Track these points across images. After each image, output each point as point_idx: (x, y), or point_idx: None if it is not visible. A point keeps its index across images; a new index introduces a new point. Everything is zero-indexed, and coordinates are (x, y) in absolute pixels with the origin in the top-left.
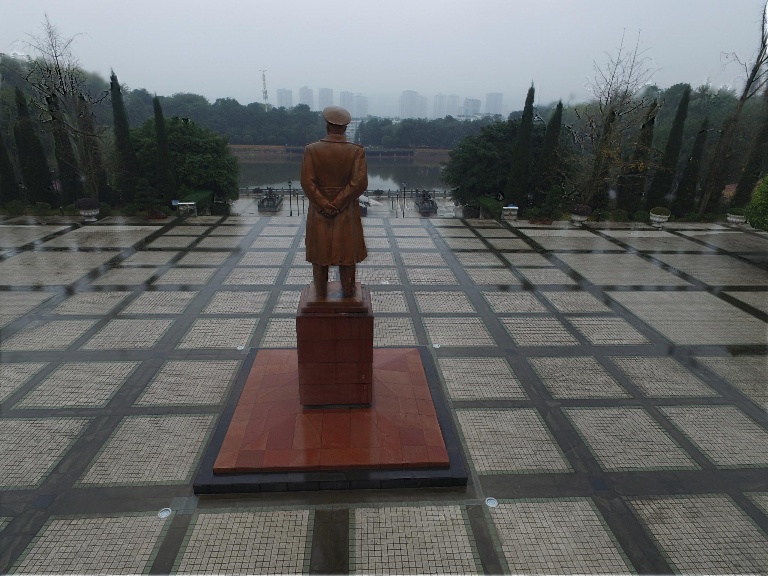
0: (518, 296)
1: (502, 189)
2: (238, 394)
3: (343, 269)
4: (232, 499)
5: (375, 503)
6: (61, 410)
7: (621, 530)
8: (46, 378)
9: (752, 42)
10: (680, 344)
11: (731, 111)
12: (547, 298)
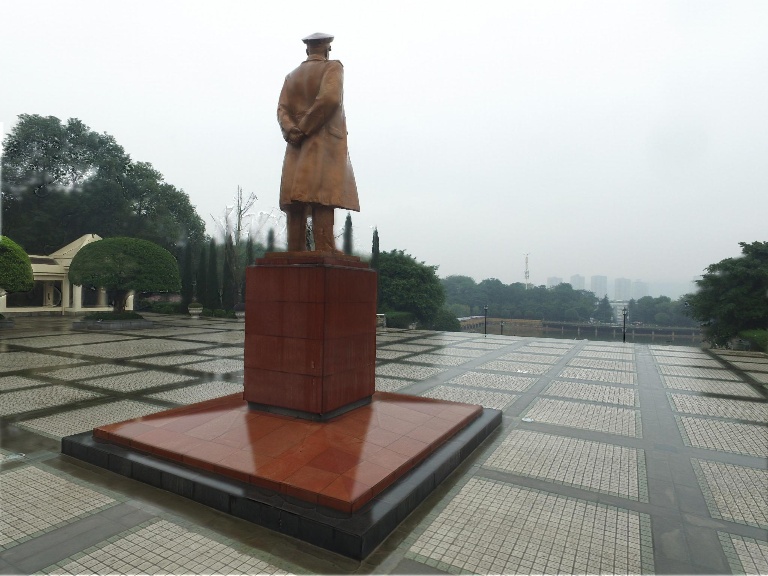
0: (741, 404)
1: None
2: None
3: (313, 215)
4: (78, 466)
5: (195, 524)
6: (98, 388)
7: None
8: (126, 374)
9: None
10: None
11: None
12: None
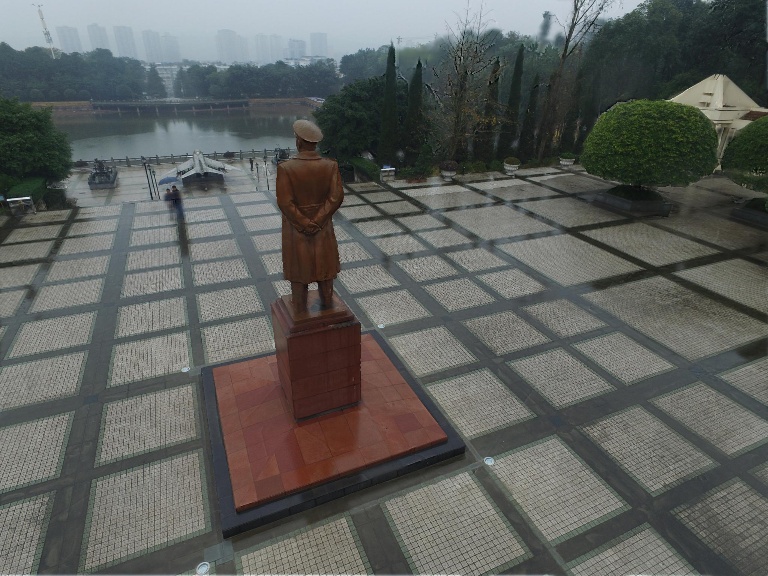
0: (429, 262)
1: (373, 149)
2: (216, 423)
3: (324, 282)
4: (265, 531)
5: (399, 492)
6: (3, 495)
7: (586, 454)
8: None
9: (567, 5)
10: (567, 286)
11: (556, 68)
12: (454, 260)
